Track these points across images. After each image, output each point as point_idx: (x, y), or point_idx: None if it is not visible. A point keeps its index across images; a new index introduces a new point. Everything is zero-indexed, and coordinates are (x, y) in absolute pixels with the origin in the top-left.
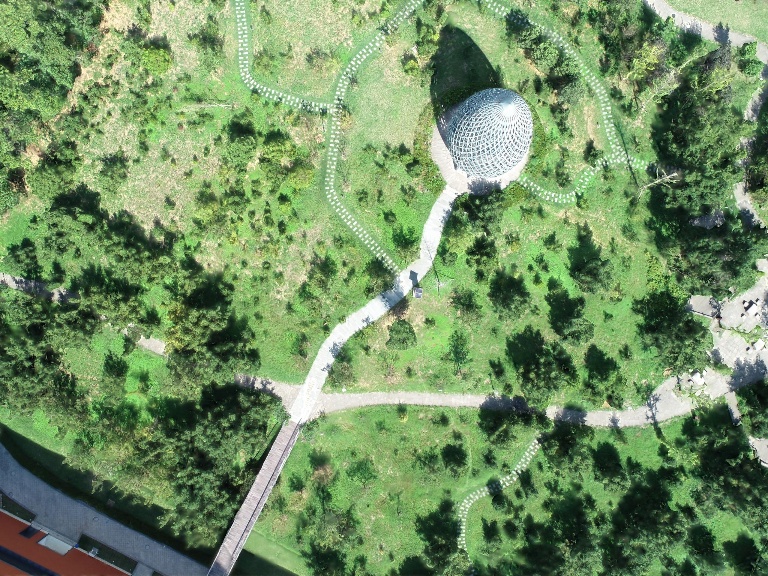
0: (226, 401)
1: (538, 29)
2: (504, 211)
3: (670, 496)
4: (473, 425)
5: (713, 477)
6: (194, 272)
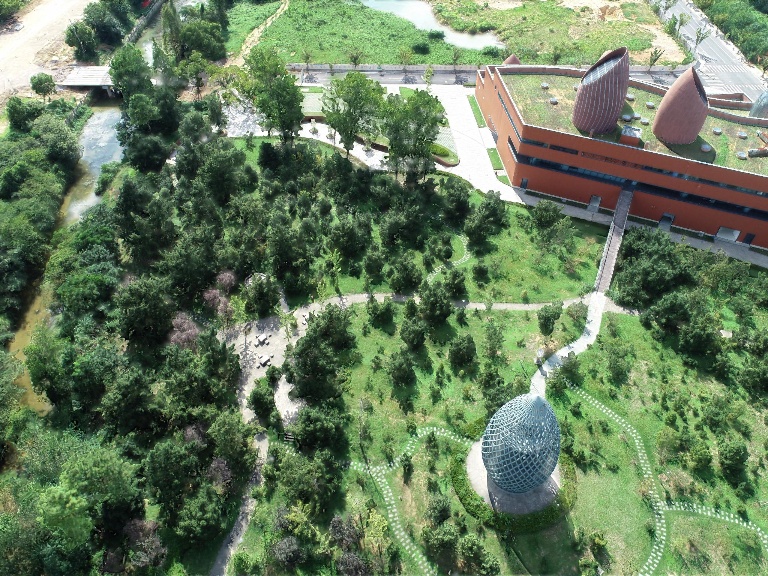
0: (655, 303)
1: (484, 572)
2: None
3: None
4: (472, 293)
5: (310, 258)
6: (722, 370)
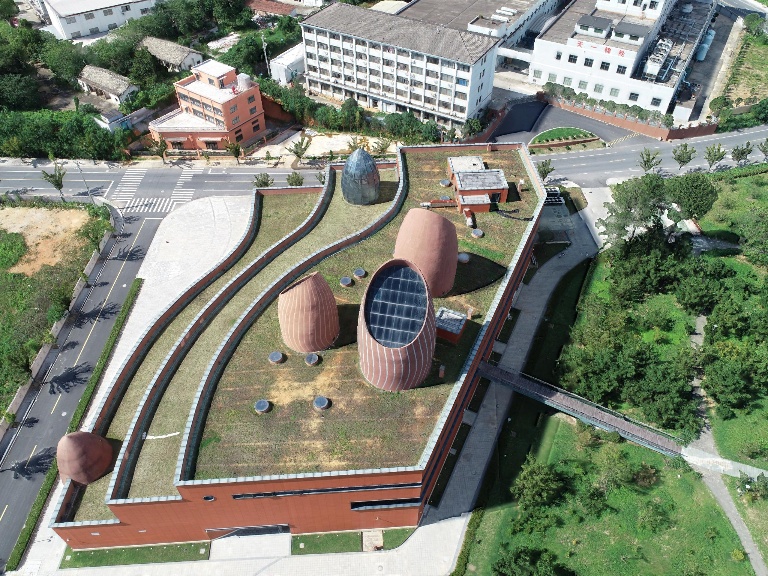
0: None
1: None
2: None
3: None
4: None
5: None
6: None
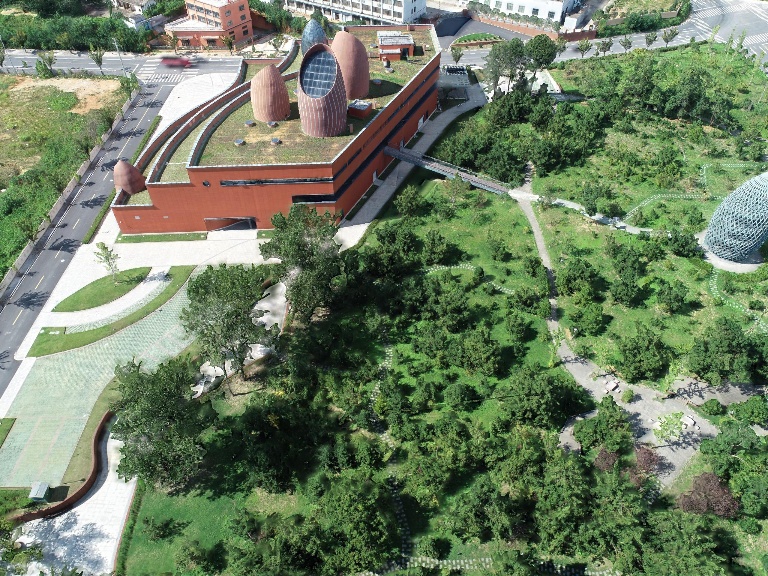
0: None
1: None
2: (689, 262)
3: (503, 378)
4: None
5: None
6: None
